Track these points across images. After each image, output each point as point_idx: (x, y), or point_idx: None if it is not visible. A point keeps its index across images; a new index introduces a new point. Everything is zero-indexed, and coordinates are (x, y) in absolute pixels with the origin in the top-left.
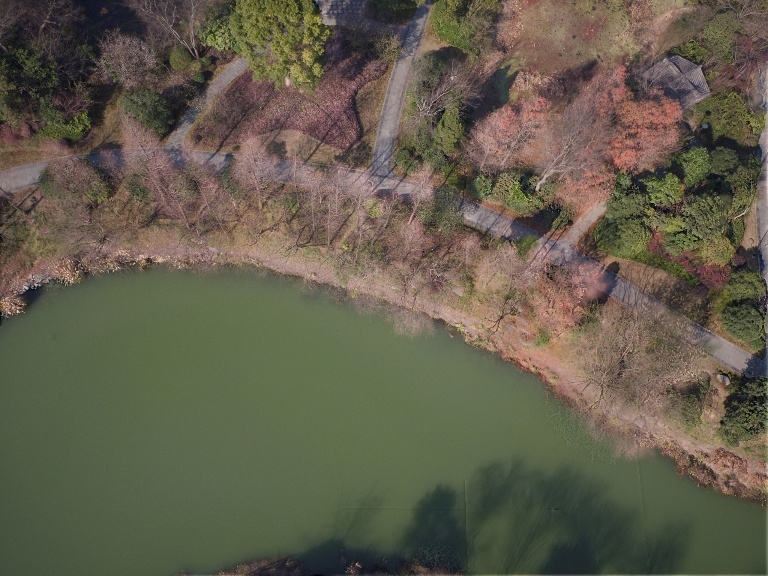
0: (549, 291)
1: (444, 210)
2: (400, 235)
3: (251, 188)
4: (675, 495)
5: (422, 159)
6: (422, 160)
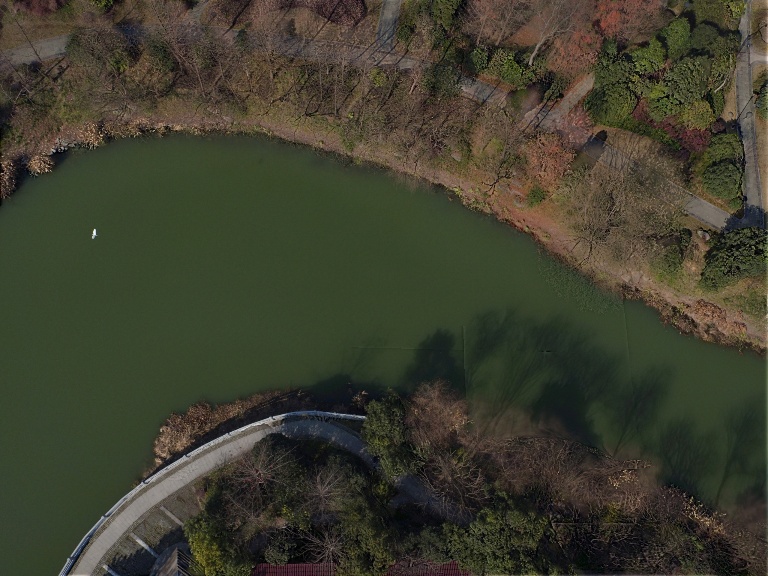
0: (541, 155)
1: (443, 82)
2: (402, 104)
3: (263, 59)
4: (659, 341)
5: (422, 35)
6: (422, 36)
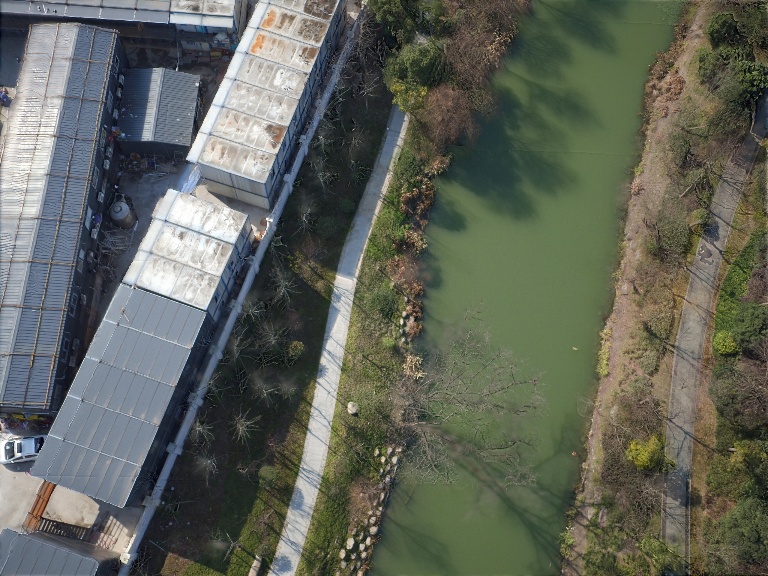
0: None
1: None
2: None
3: None
4: (639, 48)
5: None
6: None
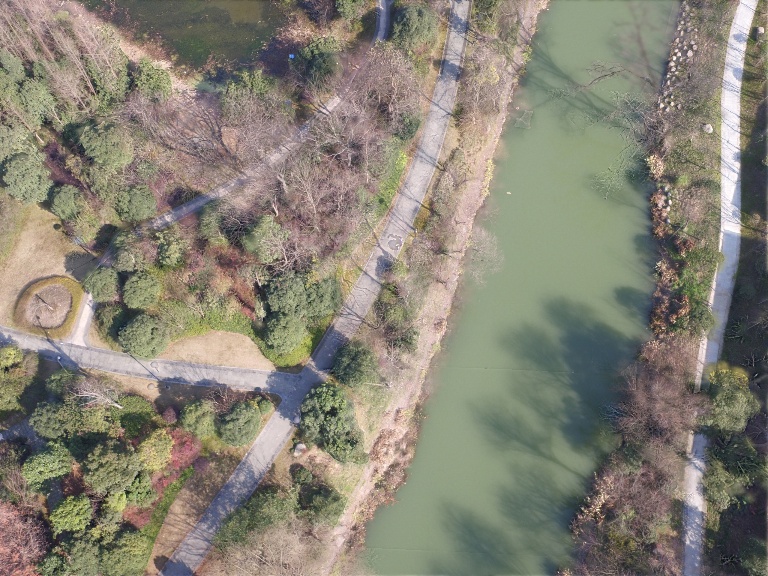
0: None
1: None
2: None
3: None
4: (414, 511)
5: None
6: None
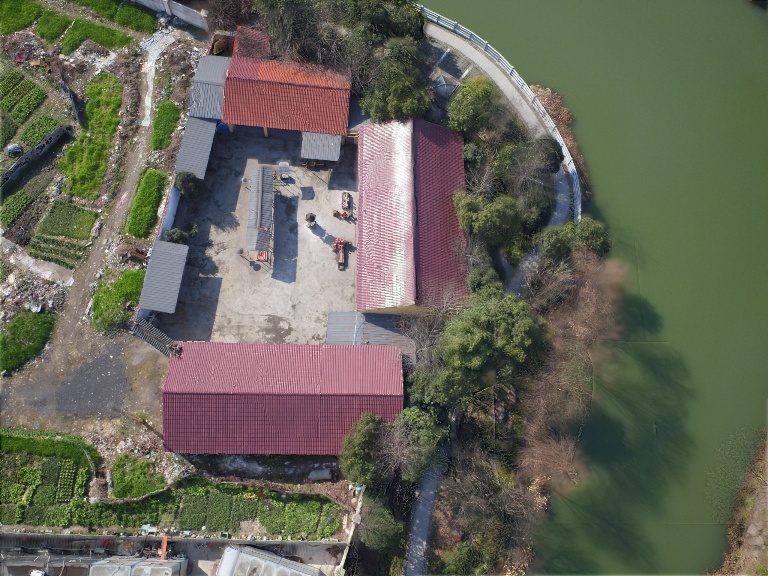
0: None
1: None
2: None
3: None
4: (685, 563)
5: None
6: None
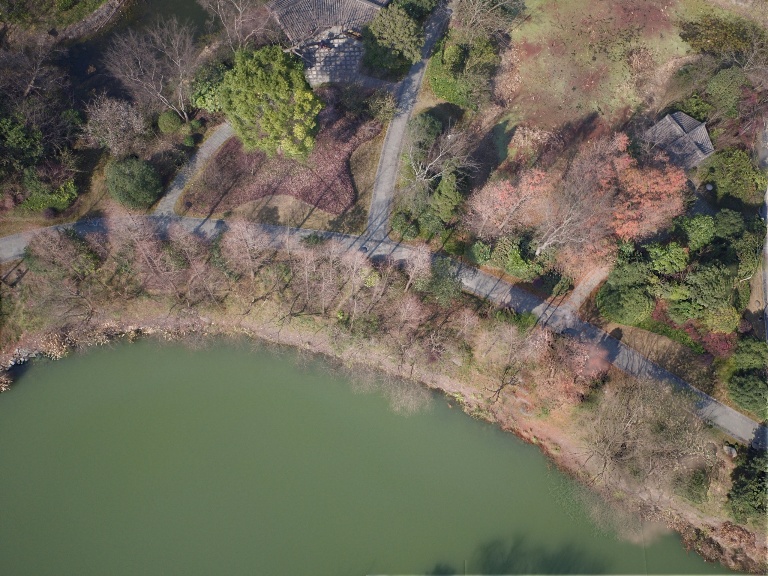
0: (550, 360)
1: (442, 276)
2: (396, 303)
3: (243, 257)
4: (681, 571)
5: (419, 224)
6: (419, 225)
